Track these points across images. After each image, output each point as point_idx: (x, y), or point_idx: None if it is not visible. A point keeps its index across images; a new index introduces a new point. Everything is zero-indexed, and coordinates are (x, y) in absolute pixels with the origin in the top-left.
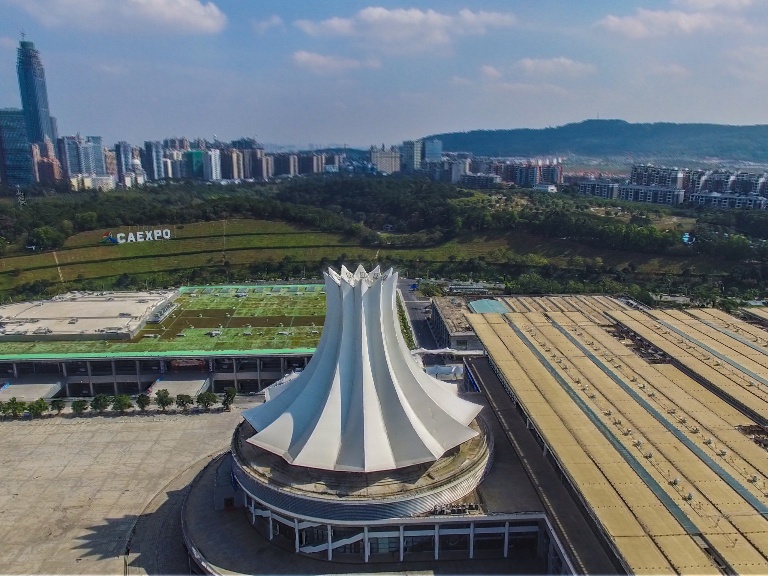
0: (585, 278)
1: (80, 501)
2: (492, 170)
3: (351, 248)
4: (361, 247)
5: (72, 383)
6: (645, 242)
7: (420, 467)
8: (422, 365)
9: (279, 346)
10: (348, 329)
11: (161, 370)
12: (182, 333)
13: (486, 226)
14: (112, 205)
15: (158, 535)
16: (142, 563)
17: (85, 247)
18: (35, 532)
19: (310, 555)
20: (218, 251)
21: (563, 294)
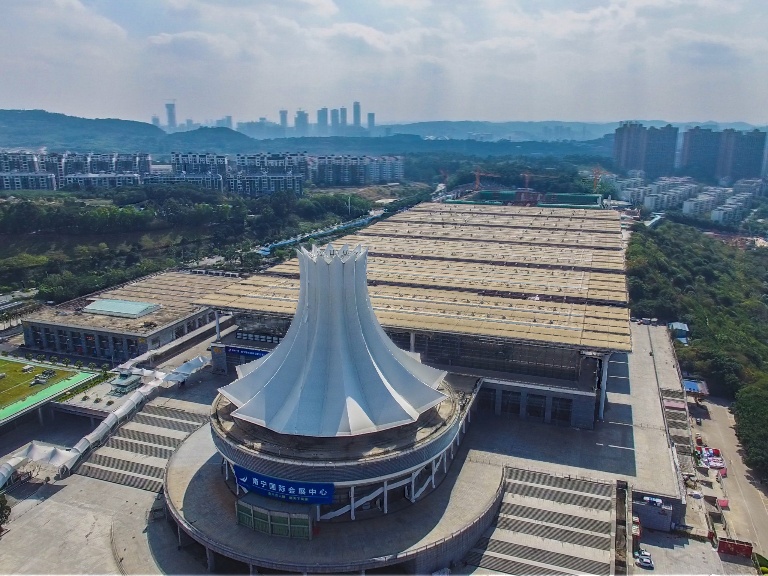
0: (99, 266)
1: None
2: None
3: None
4: None
5: None
6: (131, 221)
7: None
8: None
9: None
10: None
11: None
12: None
13: None
14: None
15: None
16: None
17: None
18: None
19: (423, 496)
20: None
21: (135, 280)
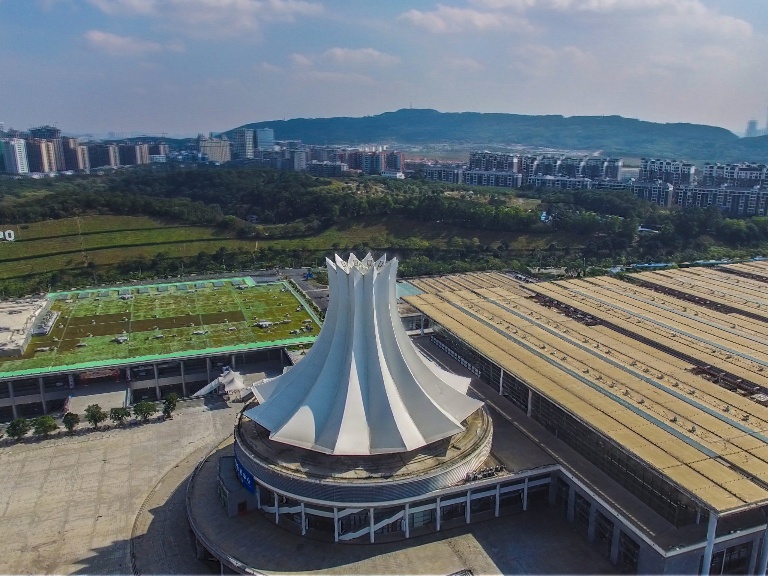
0: (465, 257)
1: (49, 537)
2: (337, 158)
3: (227, 241)
4: (238, 239)
5: None
6: (513, 222)
7: (443, 440)
8: None
9: (202, 346)
10: (359, 316)
11: (70, 385)
12: (82, 343)
13: (362, 213)
14: None
15: (164, 555)
16: None
17: None
18: None
19: (351, 542)
20: (76, 252)
21: (458, 273)
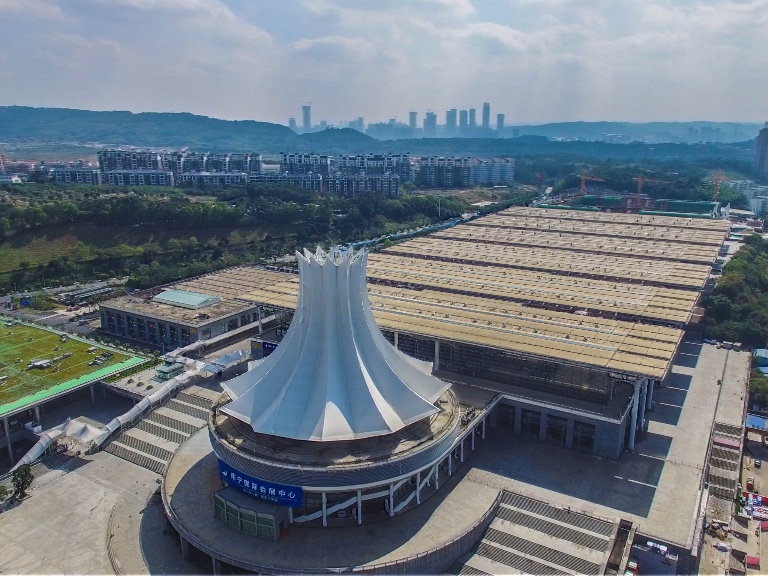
0: (188, 258)
1: None
2: None
3: None
4: None
5: None
6: (222, 218)
7: None
8: None
9: None
10: (349, 305)
11: None
12: None
13: (39, 224)
14: None
15: None
16: None
17: None
18: None
19: (404, 510)
20: None
21: (211, 273)
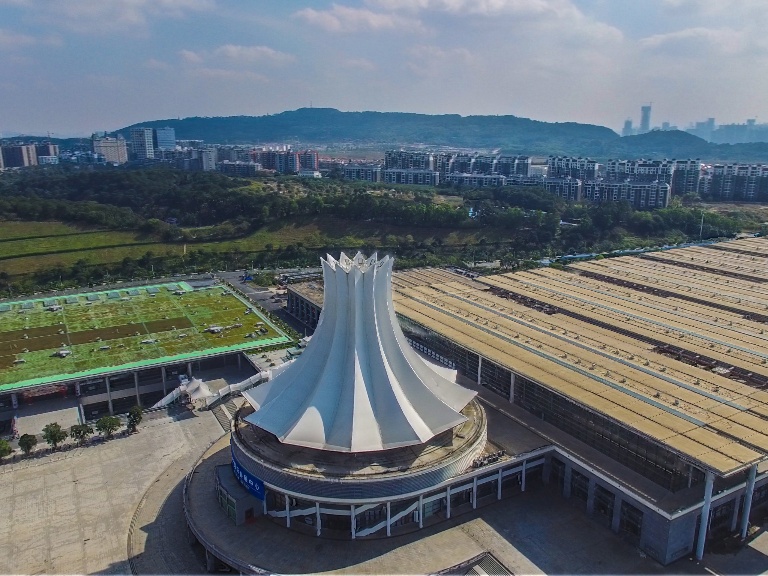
0: (401, 254)
1: (35, 567)
2: (249, 158)
3: (152, 245)
4: (164, 243)
5: None
6: (443, 218)
7: None
8: None
9: (155, 355)
10: (359, 315)
11: (13, 405)
12: (20, 359)
13: (292, 213)
14: None
15: (170, 572)
16: None
17: None
18: None
19: (368, 537)
20: None
21: (401, 270)
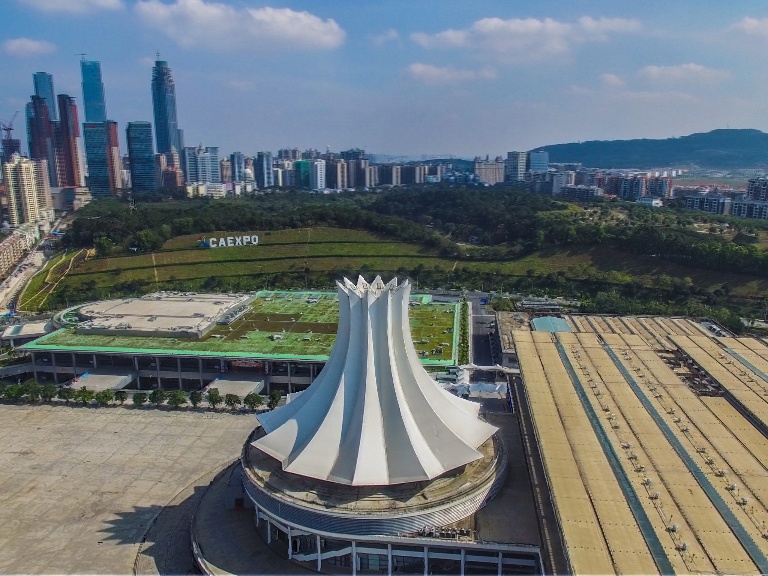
0: (671, 299)
1: (117, 487)
2: (594, 182)
3: (429, 259)
4: (439, 258)
5: (143, 376)
6: (743, 262)
7: (416, 485)
8: (468, 381)
9: None
10: (355, 340)
11: (221, 369)
12: (246, 335)
13: (570, 240)
14: (215, 211)
15: (175, 527)
16: (153, 552)
17: (180, 250)
18: (71, 512)
19: (301, 563)
20: (301, 258)
21: (639, 315)
